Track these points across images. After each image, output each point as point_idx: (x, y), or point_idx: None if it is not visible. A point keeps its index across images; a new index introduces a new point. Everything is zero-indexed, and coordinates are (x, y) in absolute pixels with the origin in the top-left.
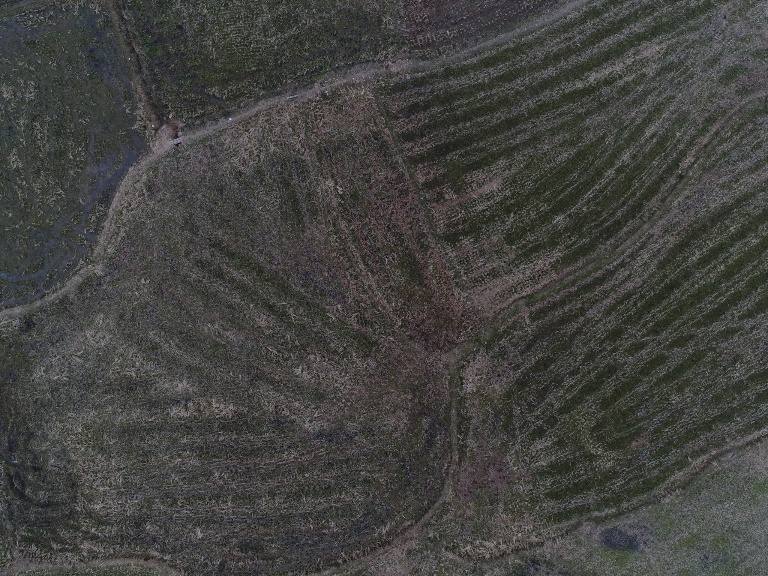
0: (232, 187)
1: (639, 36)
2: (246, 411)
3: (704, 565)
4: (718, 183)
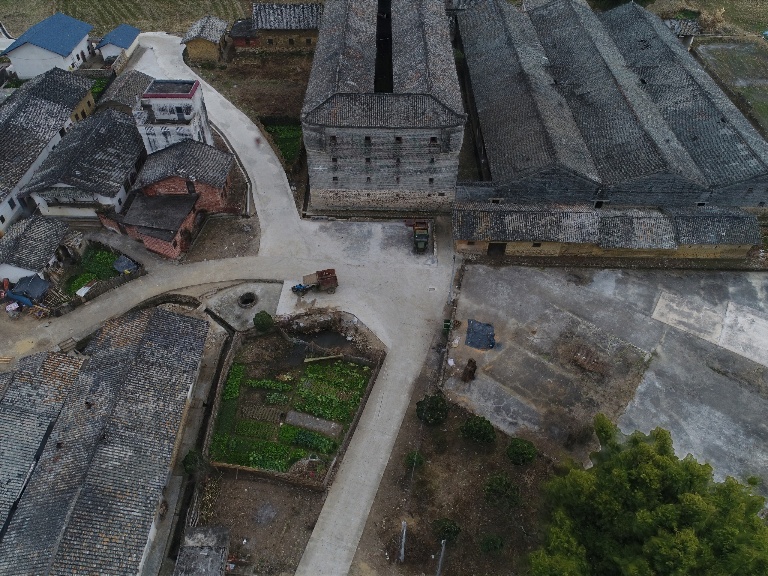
0: None
1: None
2: None
3: (18, 0)
4: None
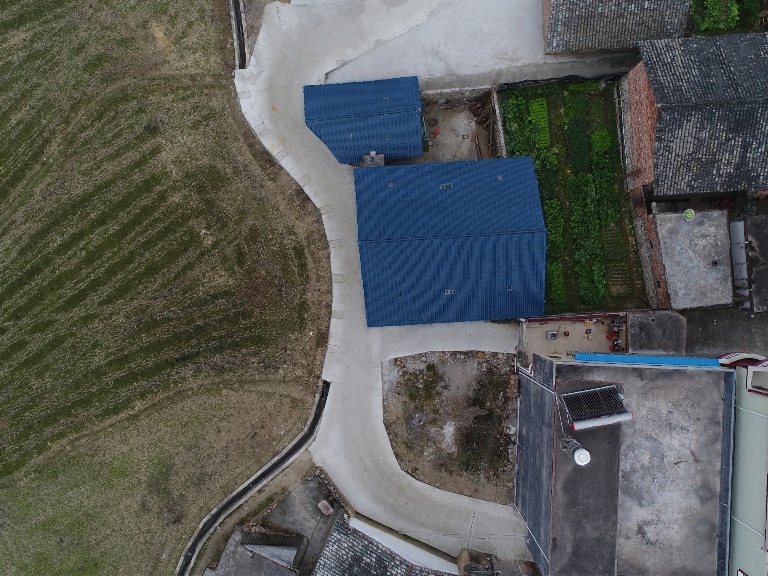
0: None
1: (6, 24)
2: None
3: (60, 548)
4: (80, 170)
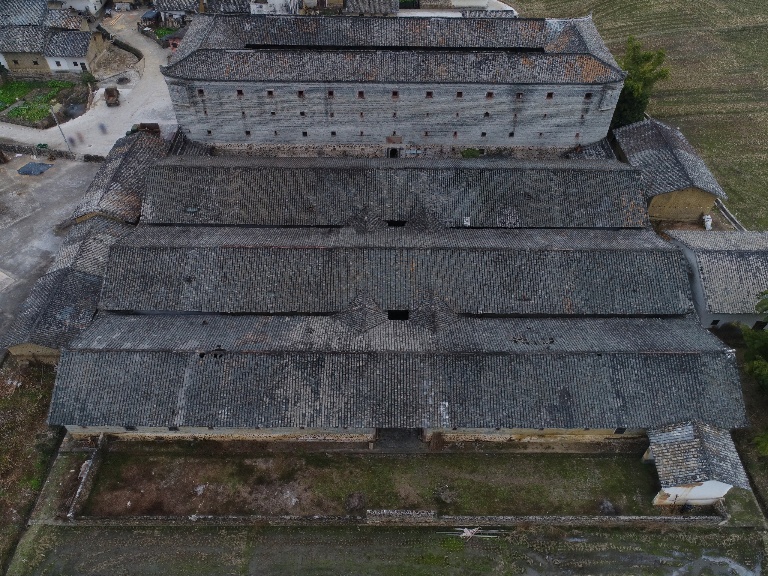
0: (760, 13)
1: (614, 29)
2: None
3: None
4: None
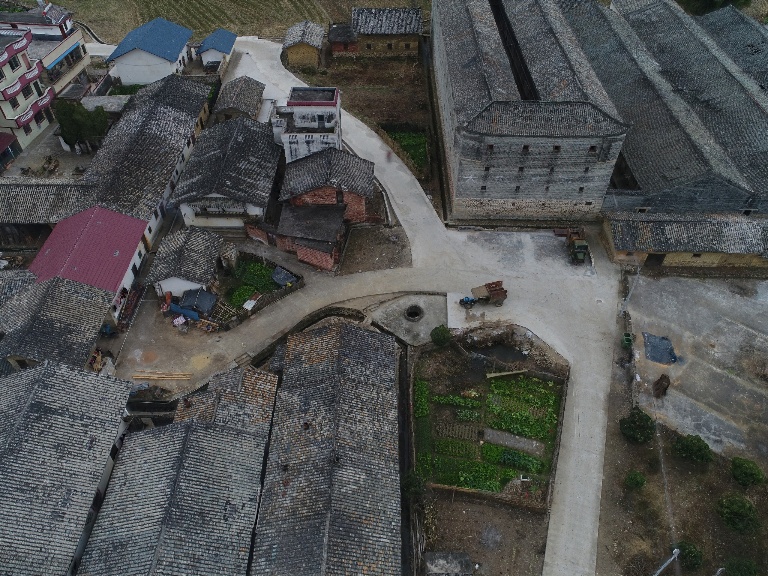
0: None
1: None
2: None
3: (99, 4)
4: None
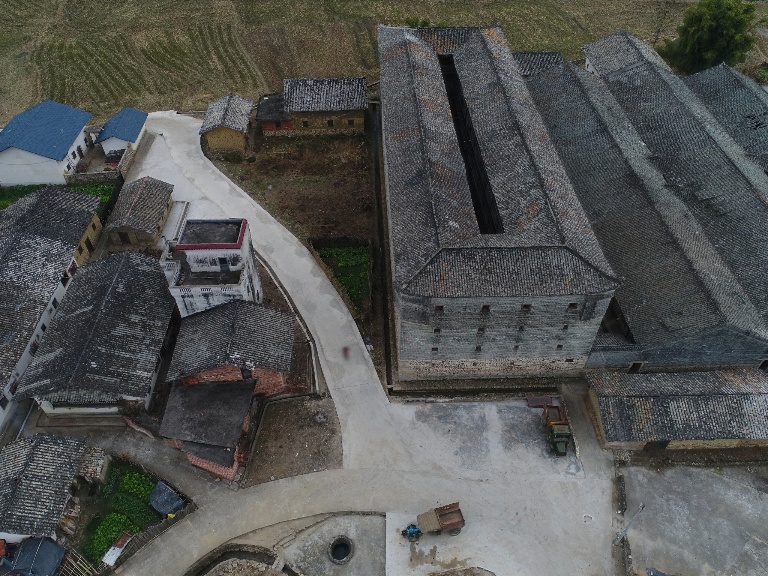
0: (208, 2)
1: None
2: (128, 2)
3: None
4: None
